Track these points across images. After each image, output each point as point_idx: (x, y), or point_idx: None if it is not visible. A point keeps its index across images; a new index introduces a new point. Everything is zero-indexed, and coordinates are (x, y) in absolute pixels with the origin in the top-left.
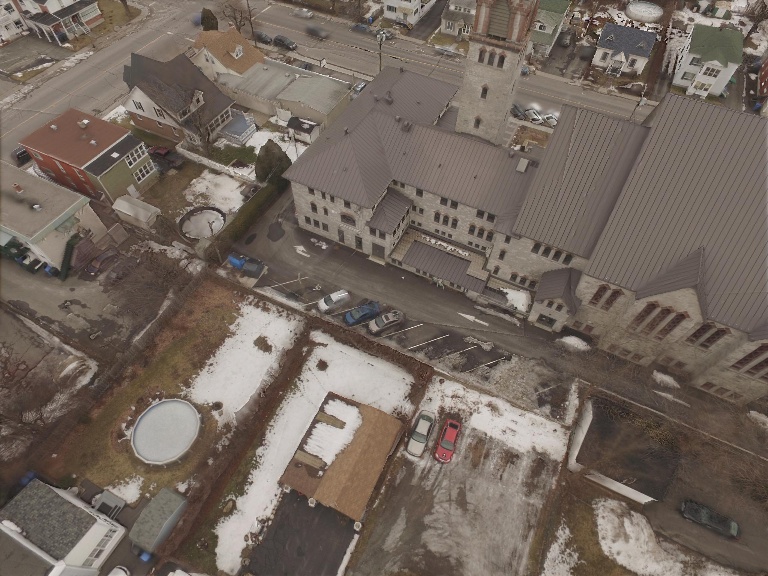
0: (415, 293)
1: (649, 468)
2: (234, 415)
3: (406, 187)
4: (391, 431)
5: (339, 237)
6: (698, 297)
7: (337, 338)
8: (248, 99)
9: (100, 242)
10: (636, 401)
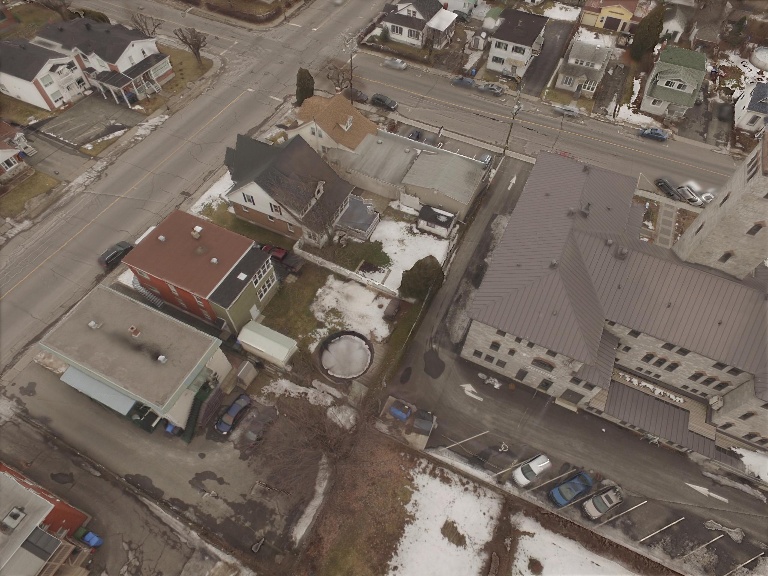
0: (625, 453)
1: None
2: None
3: (617, 325)
4: None
5: (517, 374)
6: None
7: None
8: (364, 180)
9: (224, 382)
10: None
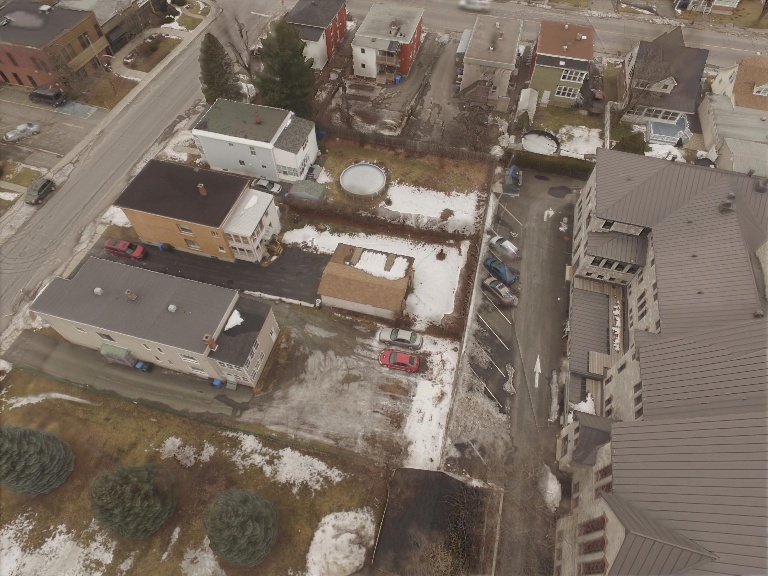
0: (545, 312)
1: (402, 544)
2: None
3: None
4: (390, 303)
5: None
6: (620, 550)
7: None
8: (709, 124)
9: (493, 101)
10: (497, 569)
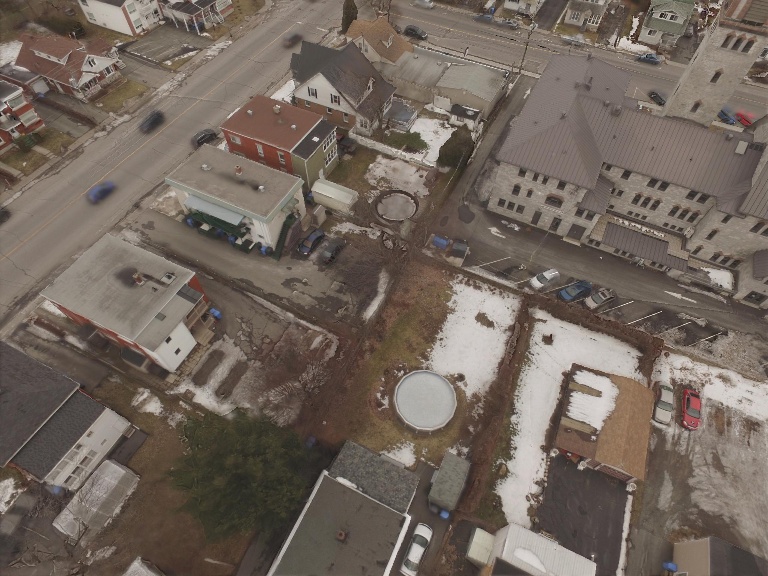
0: (617, 272)
1: None
2: (479, 386)
3: (612, 170)
4: (647, 399)
5: (532, 219)
6: None
7: (555, 314)
8: (404, 87)
9: None
10: None
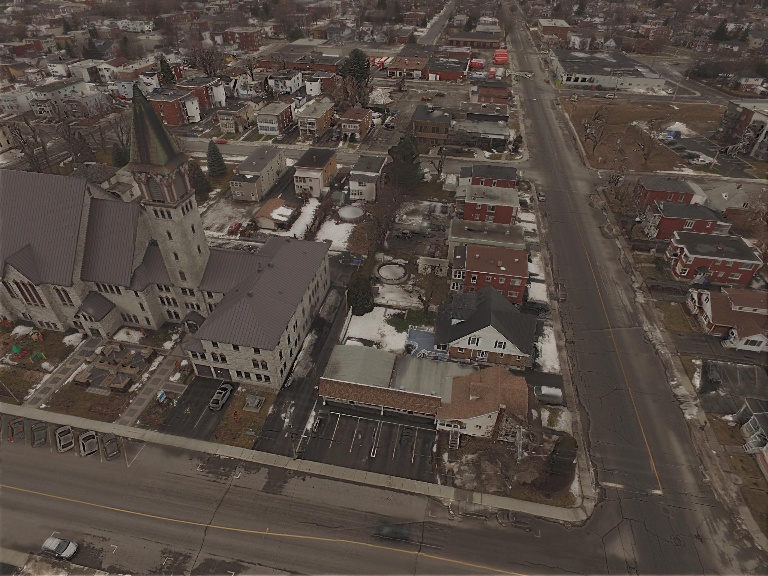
0: None
1: None
2: None
3: None
4: None
5: None
6: None
7: None
8: None
9: None
10: None
